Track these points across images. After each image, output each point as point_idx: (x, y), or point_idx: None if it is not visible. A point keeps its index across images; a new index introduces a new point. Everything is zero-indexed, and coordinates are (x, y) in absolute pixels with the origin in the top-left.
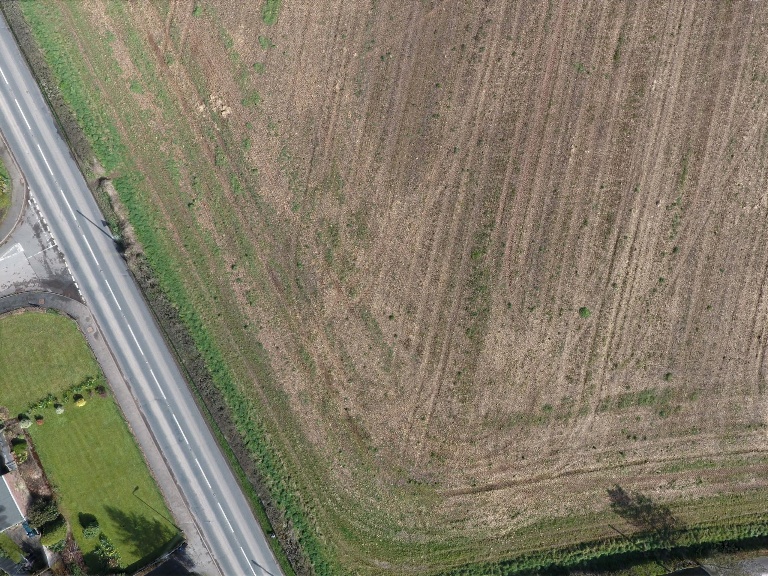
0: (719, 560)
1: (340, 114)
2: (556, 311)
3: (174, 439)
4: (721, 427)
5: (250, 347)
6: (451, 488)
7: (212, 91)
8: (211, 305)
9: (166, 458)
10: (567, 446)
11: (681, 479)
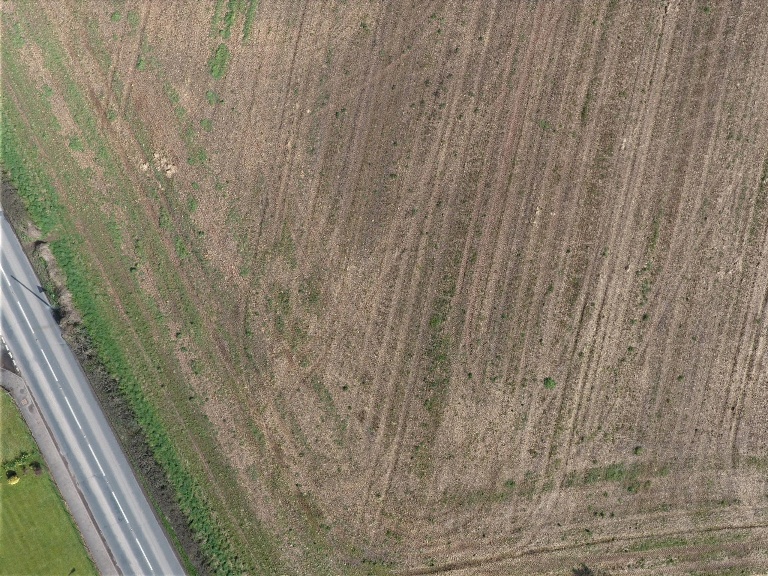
0: None
1: (292, 174)
2: (519, 381)
3: (113, 518)
4: (693, 503)
5: (195, 420)
6: (408, 568)
7: (156, 149)
8: (154, 375)
9: (105, 538)
10: (530, 523)
11: (650, 557)
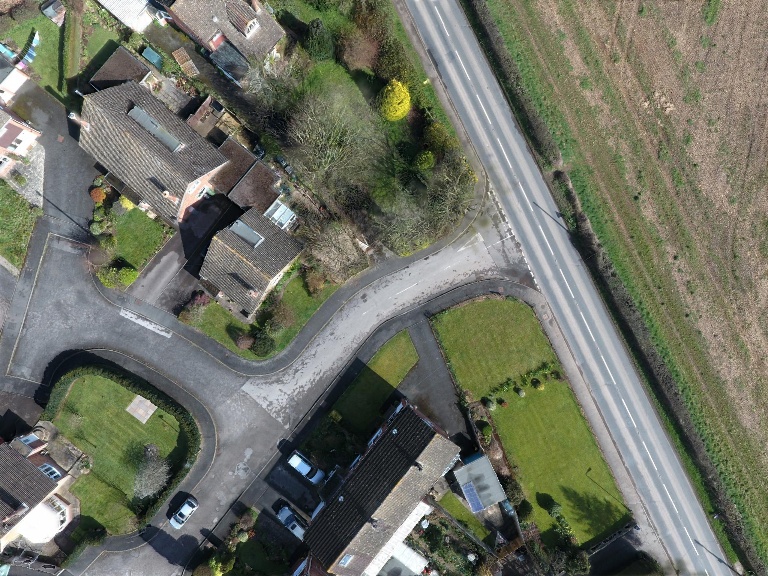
0: None
1: None
2: None
3: (623, 423)
4: None
5: (691, 335)
6: None
7: (656, 88)
8: (655, 294)
9: (615, 441)
10: None
11: None
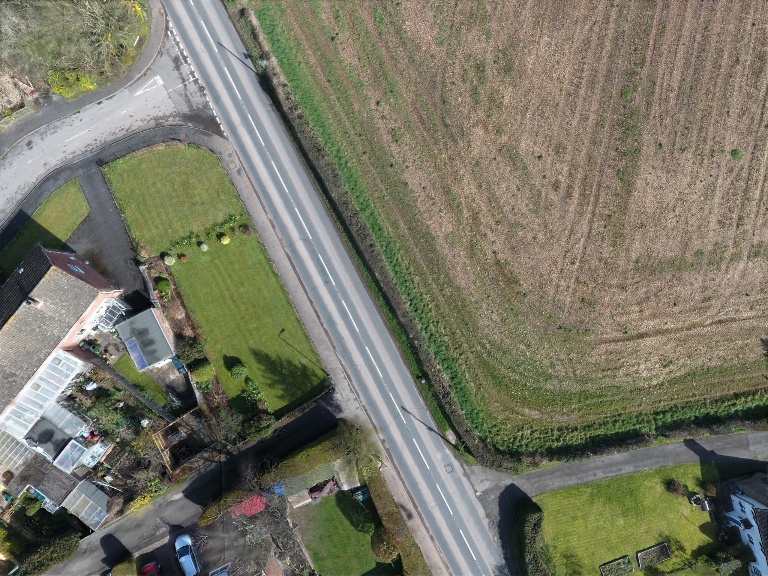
0: None
1: None
2: (708, 152)
3: (320, 280)
4: None
5: (396, 186)
6: (602, 335)
7: None
8: (356, 143)
9: (312, 300)
10: (719, 293)
11: None
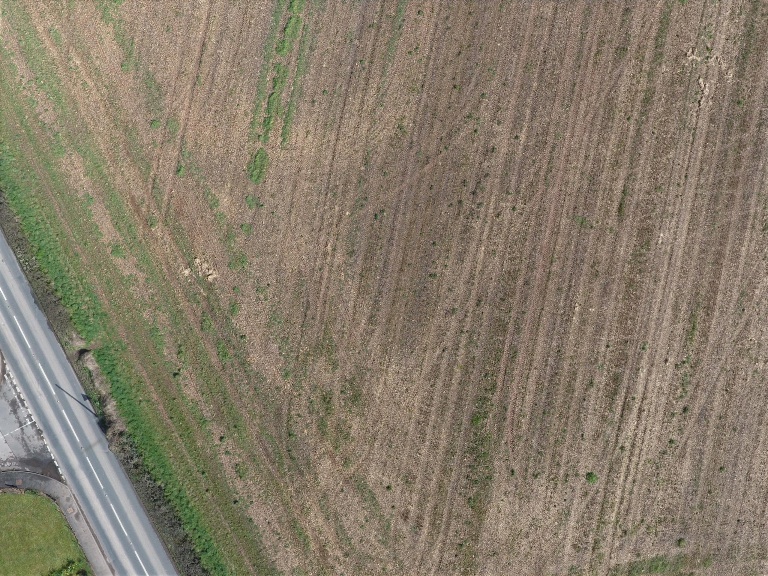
0: None
1: (332, 275)
2: (562, 477)
3: None
4: None
5: (240, 523)
6: None
7: (197, 254)
8: (198, 480)
9: None
10: None
11: None
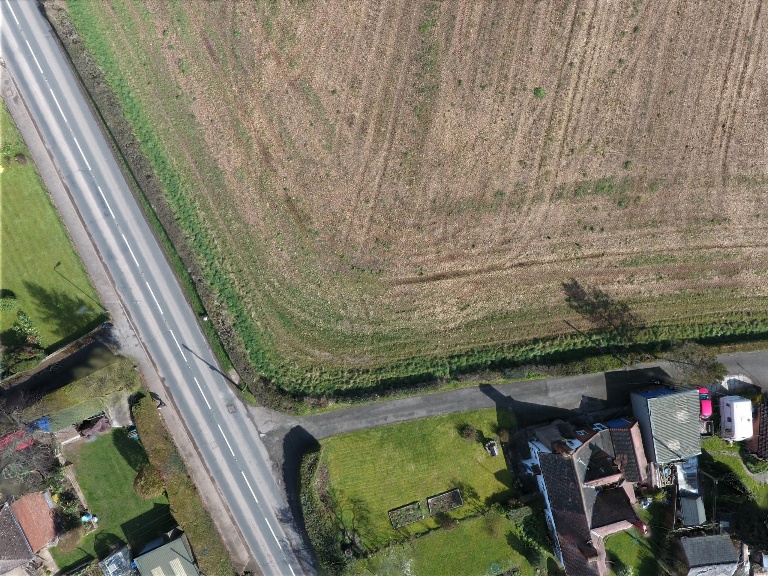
0: (678, 354)
1: None
2: (509, 90)
3: (99, 213)
4: (683, 220)
5: (182, 119)
6: (397, 276)
7: None
8: (140, 72)
9: (91, 233)
10: (520, 235)
11: (640, 274)
